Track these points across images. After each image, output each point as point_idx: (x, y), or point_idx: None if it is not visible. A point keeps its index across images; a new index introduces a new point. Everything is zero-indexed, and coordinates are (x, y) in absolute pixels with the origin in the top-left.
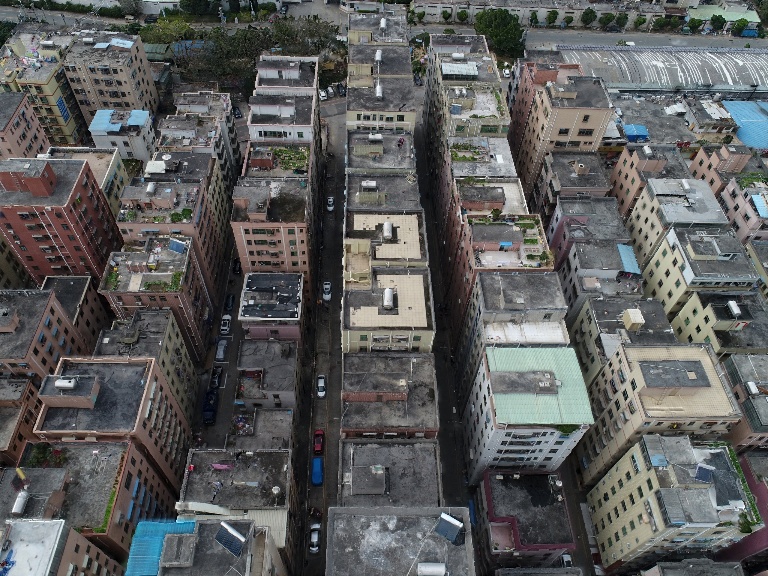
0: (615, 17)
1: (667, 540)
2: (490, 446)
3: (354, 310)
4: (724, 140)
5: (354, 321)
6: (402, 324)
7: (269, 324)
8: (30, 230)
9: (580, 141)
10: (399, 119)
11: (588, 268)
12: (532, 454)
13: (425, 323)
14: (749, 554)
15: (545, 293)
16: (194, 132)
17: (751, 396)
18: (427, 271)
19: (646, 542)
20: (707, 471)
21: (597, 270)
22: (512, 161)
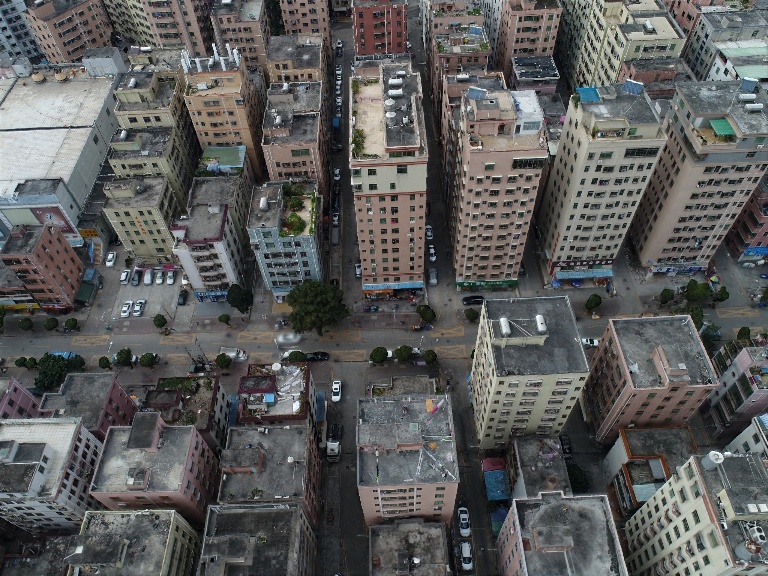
0: None
1: None
2: None
3: (628, 34)
4: None
5: (630, 38)
6: (662, 38)
7: (537, 84)
8: (375, 28)
9: None
10: None
11: None
12: None
13: (677, 37)
14: None
15: (751, 20)
16: None
17: None
18: (667, 14)
19: None
20: None
21: None
22: None
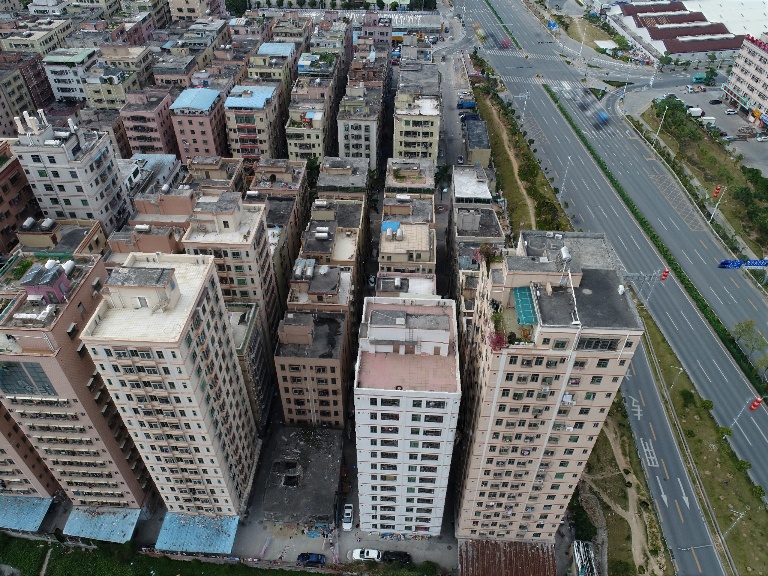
0: (318, 2)
1: (96, 101)
2: (52, 84)
3: None
4: None
5: None
6: None
7: None
8: None
9: (191, 16)
10: (97, 2)
11: None
12: (74, 93)
13: None
14: None
15: None
16: (10, 16)
17: (157, 62)
18: None
19: (90, 103)
20: (101, 63)
21: (150, 47)
22: (143, 17)
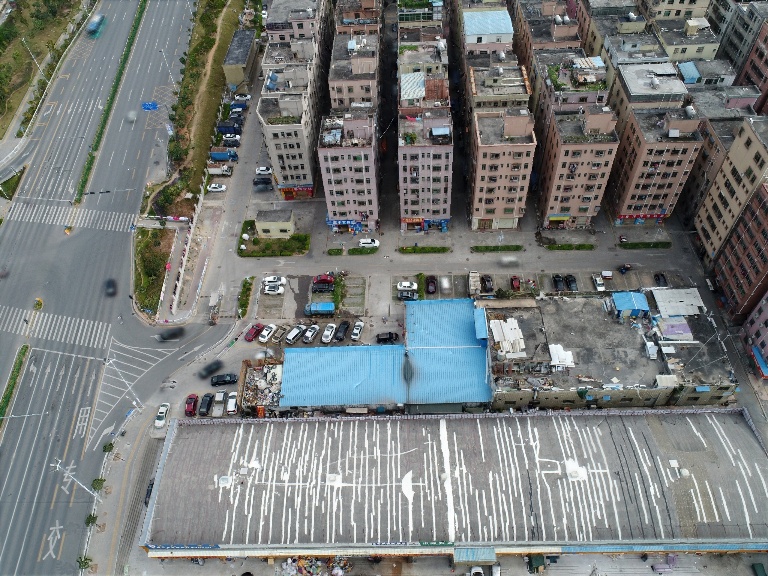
0: None
1: None
2: None
3: None
4: (506, 293)
5: None
6: None
7: None
8: None
9: None
10: None
11: (722, 61)
12: None
13: None
14: None
15: (767, 9)
16: None
17: None
18: None
19: None
20: None
21: None
22: None
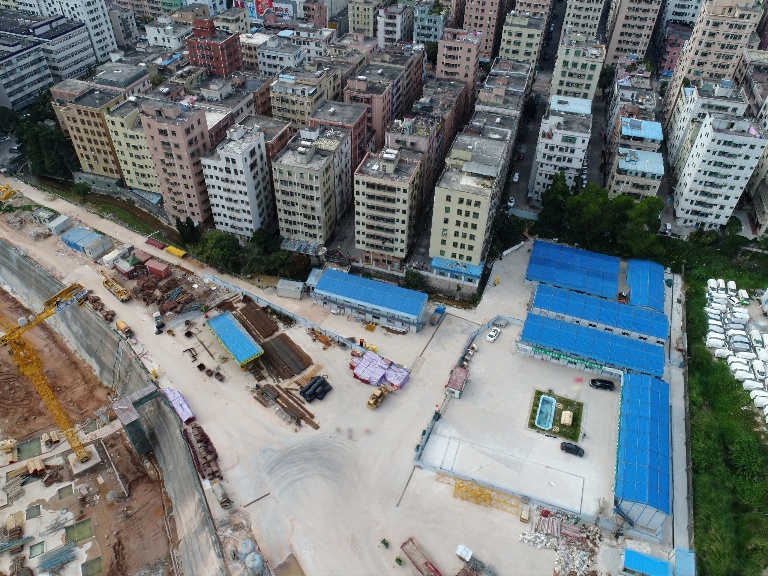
0: None
1: None
2: (670, 8)
3: None
4: None
5: None
6: None
7: None
8: None
9: None
10: None
11: None
12: (685, 17)
13: None
14: (764, 48)
15: None
16: None
17: None
18: None
19: None
20: None
21: None
22: None
